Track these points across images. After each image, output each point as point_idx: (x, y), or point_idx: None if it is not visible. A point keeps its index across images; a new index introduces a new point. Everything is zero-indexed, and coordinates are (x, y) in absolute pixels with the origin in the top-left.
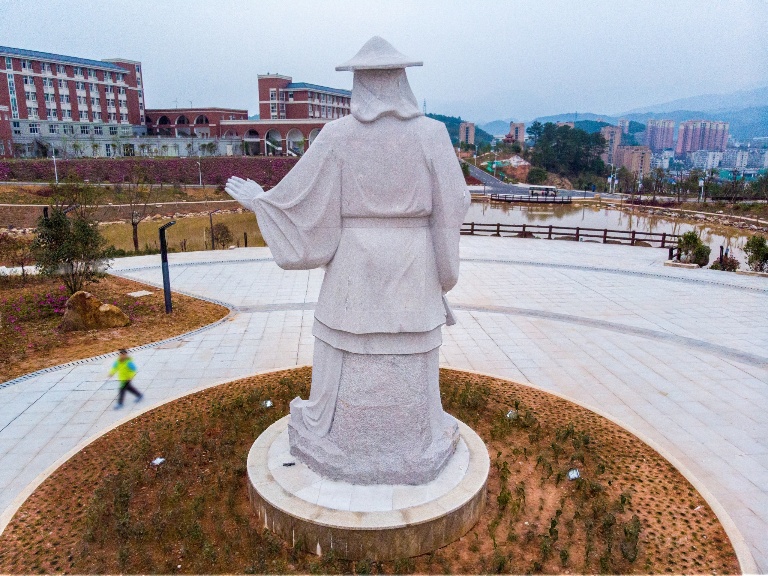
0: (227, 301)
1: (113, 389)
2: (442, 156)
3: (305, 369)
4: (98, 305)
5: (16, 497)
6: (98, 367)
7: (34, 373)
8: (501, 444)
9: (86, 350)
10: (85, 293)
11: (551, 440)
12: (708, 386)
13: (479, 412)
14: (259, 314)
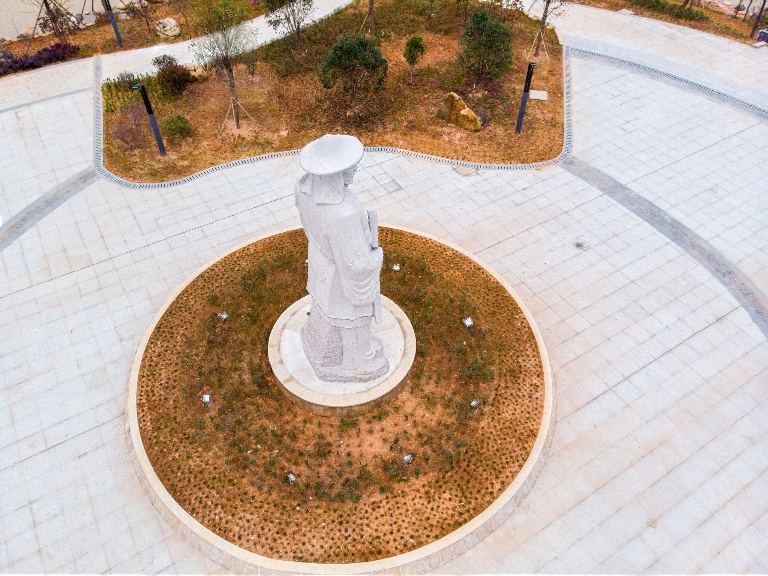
0: (576, 143)
1: (386, 189)
2: (336, 236)
3: (466, 258)
4: (463, 107)
5: (261, 235)
6: (407, 164)
7: (380, 148)
8: None
9: (425, 143)
10: (455, 96)
11: (455, 437)
12: (714, 571)
13: (467, 382)
14: (566, 175)
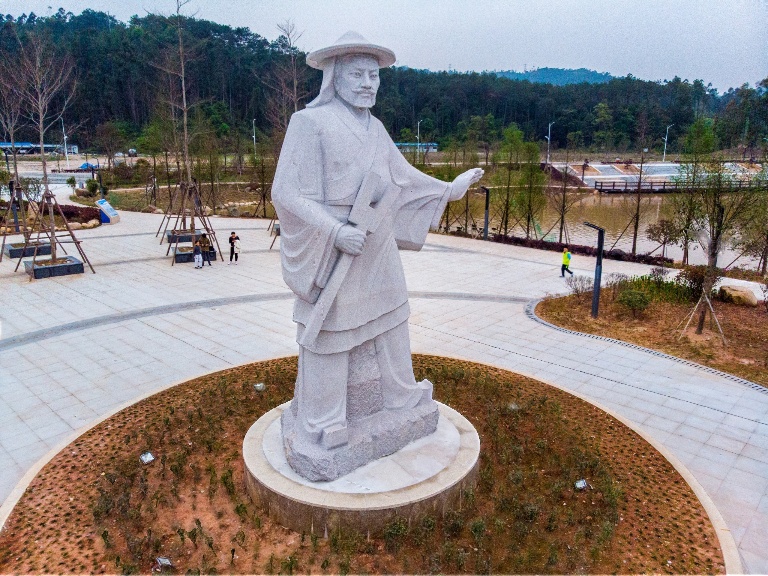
0: None
1: None
2: None
3: None
4: None
5: None
6: None
7: None
8: (275, 570)
9: None
10: None
11: None
12: None
13: None
14: None
